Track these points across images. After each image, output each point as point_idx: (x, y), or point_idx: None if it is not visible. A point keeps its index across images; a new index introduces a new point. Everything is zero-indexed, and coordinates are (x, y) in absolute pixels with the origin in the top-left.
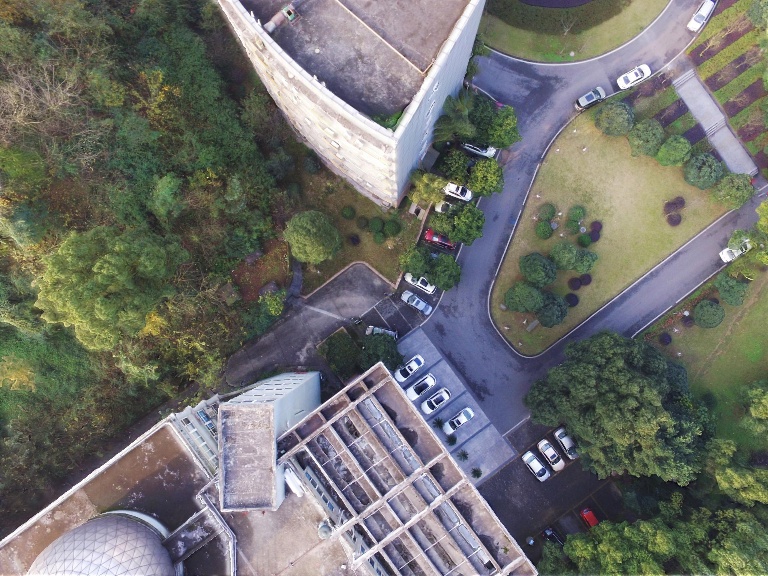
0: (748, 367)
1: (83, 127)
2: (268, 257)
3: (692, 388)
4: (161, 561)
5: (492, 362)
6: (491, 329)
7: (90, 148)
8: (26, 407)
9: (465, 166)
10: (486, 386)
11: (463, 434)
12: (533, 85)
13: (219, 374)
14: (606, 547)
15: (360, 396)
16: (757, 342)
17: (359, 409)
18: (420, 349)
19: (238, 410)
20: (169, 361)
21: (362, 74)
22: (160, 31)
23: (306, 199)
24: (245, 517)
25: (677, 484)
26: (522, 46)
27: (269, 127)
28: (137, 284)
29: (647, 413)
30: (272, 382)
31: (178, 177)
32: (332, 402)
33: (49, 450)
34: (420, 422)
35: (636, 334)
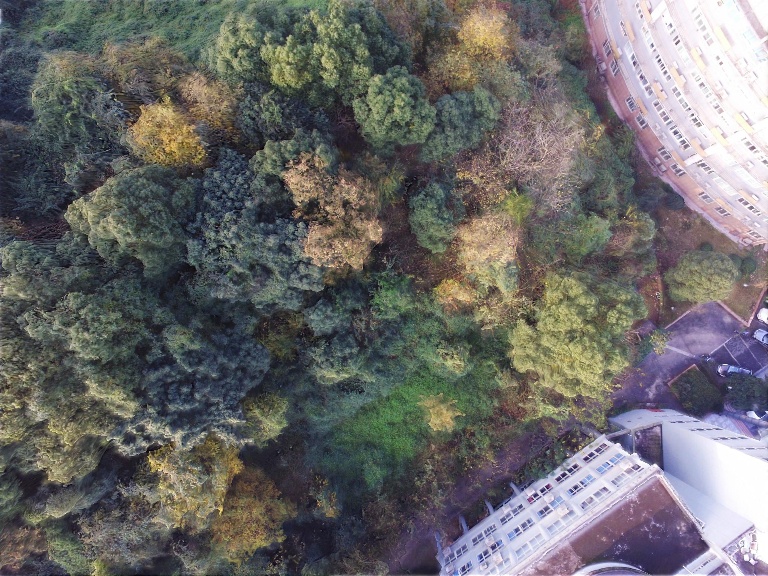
0: None
1: (558, 170)
2: None
3: None
4: None
5: None
6: None
7: (570, 192)
8: (414, 444)
9: None
10: None
11: None
12: None
13: None
14: None
15: None
16: None
17: None
18: None
19: None
20: None
21: None
22: None
23: (664, 234)
24: None
25: None
26: None
27: (633, 161)
28: None
29: None
30: (684, 426)
31: None
32: None
33: (448, 489)
34: None
35: None
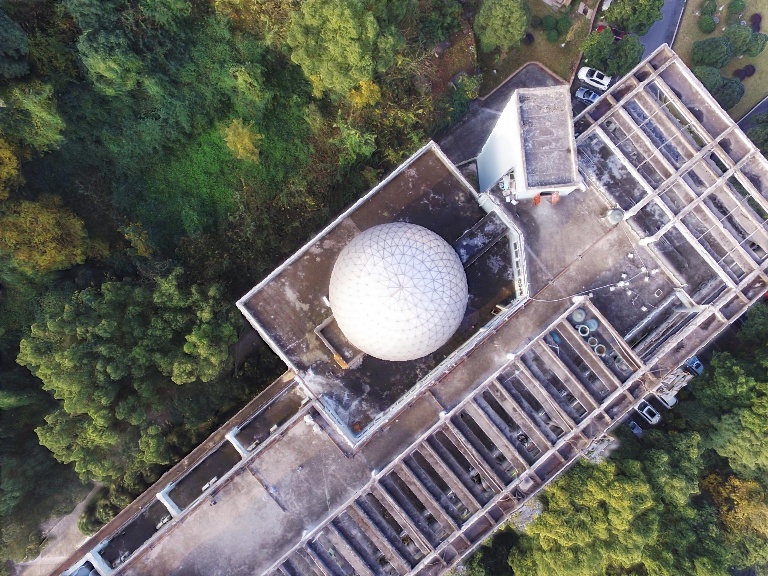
0: None
1: None
2: (454, 50)
3: None
4: None
5: None
6: None
7: None
8: None
9: None
10: None
11: None
12: None
13: None
14: None
15: None
16: None
17: None
18: None
19: (533, 94)
20: None
21: None
22: None
23: None
24: (530, 215)
25: None
26: None
27: None
28: None
29: None
30: None
31: None
32: (619, 87)
33: (267, 230)
34: (705, 101)
35: None
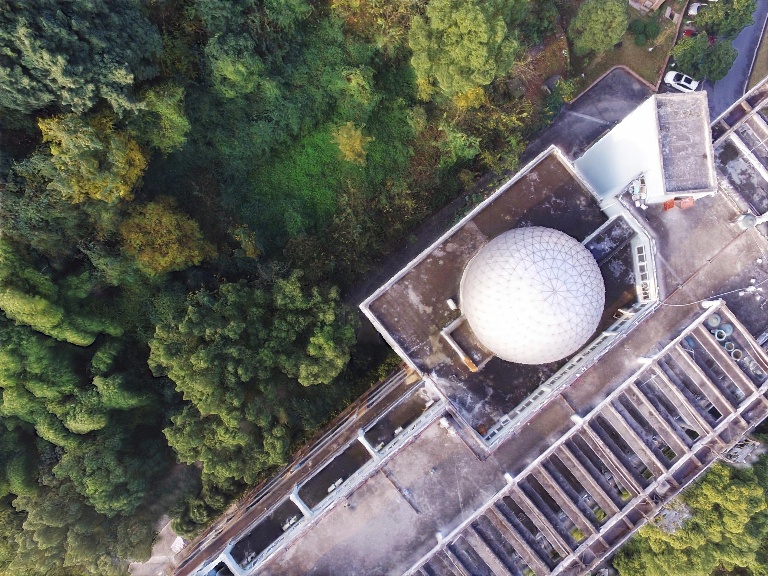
0: None
1: None
2: (547, 53)
3: None
4: None
5: None
6: None
7: None
8: (335, 197)
9: None
10: None
11: None
12: None
13: None
14: None
15: None
16: None
17: None
18: None
19: (669, 100)
20: None
21: None
22: None
23: None
24: (659, 220)
25: None
26: None
27: None
28: None
29: None
30: None
31: None
32: (752, 93)
33: (370, 232)
34: None
35: None
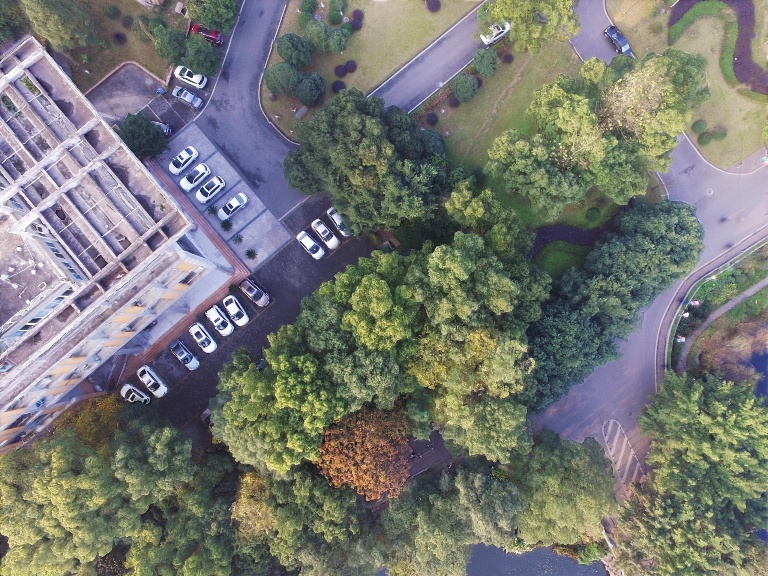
0: None
1: None
2: None
3: (462, 165)
4: None
5: (266, 151)
6: (263, 119)
7: None
8: None
9: None
10: (261, 174)
11: (240, 221)
12: None
13: None
14: (338, 274)
15: (13, 69)
16: (523, 119)
17: (16, 85)
18: (195, 143)
19: None
20: None
21: None
22: None
23: None
24: None
25: None
26: None
27: None
28: None
29: (365, 139)
30: None
31: None
32: None
33: None
34: (75, 93)
35: None
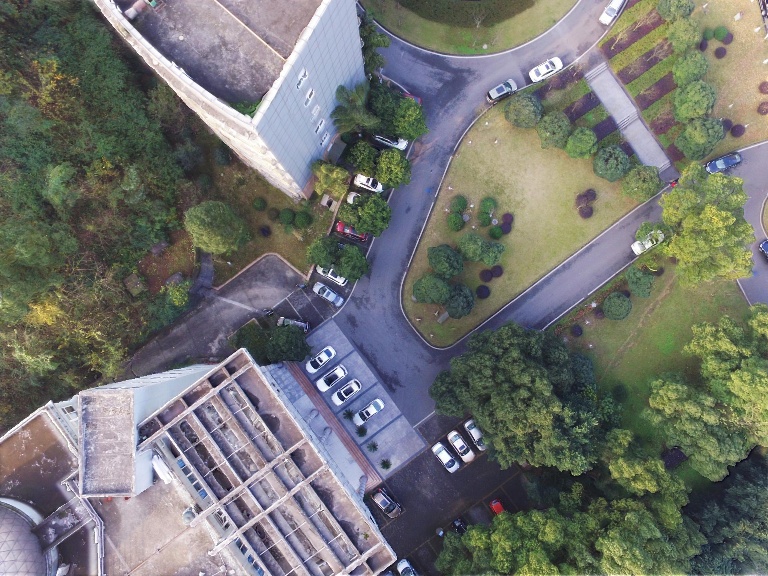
0: (659, 359)
1: None
2: (175, 248)
3: (603, 380)
4: (26, 547)
5: (404, 354)
6: (403, 321)
7: None
8: None
9: (371, 157)
10: (397, 377)
11: (374, 425)
12: (446, 77)
13: (121, 364)
14: (497, 536)
15: (221, 382)
16: (669, 334)
17: (222, 395)
18: (332, 340)
19: (99, 396)
20: (72, 351)
21: (226, 61)
22: (63, 21)
23: (217, 190)
24: (113, 504)
25: (584, 475)
26: (435, 39)
27: (179, 118)
28: (17, 272)
29: (537, 402)
30: (168, 372)
31: (73, 166)
32: (195, 388)
33: None
34: (282, 408)
35: (548, 326)
